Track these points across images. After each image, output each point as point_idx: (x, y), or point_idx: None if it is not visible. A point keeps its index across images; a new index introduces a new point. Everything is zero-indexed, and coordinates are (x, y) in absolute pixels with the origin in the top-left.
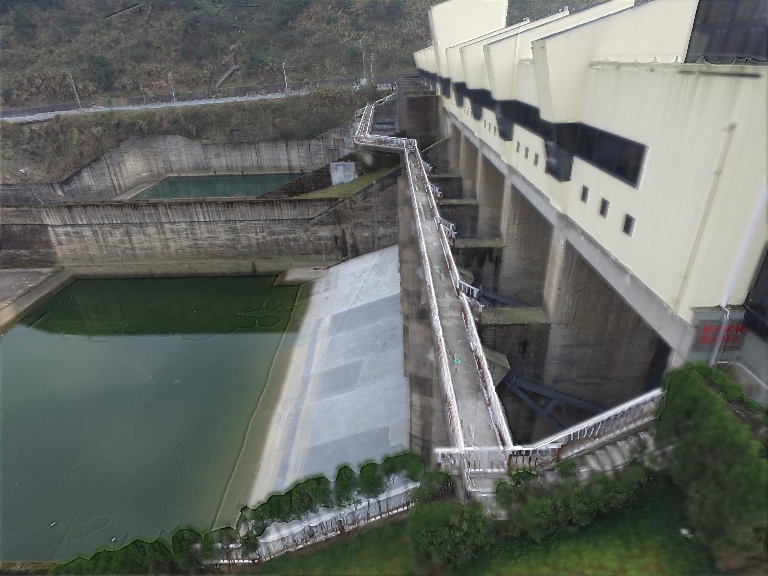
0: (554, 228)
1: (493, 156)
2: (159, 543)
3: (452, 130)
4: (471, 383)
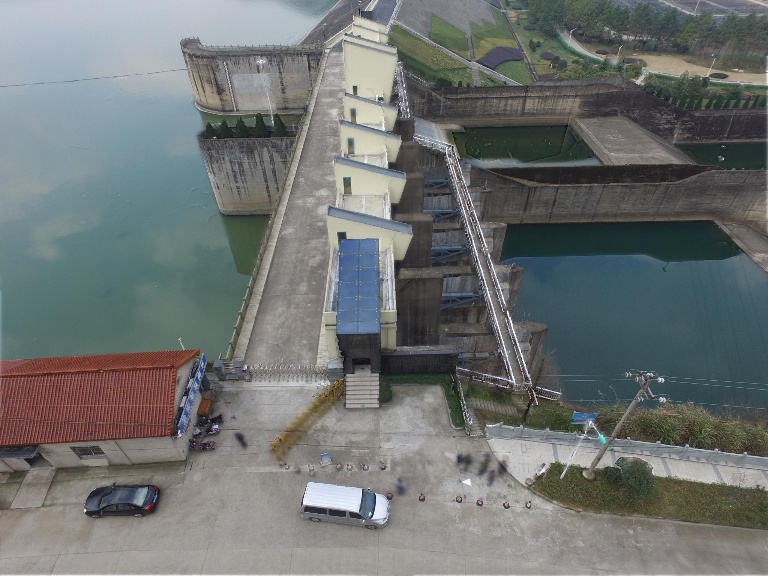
0: None
1: None
2: (437, 78)
3: None
4: (397, 71)
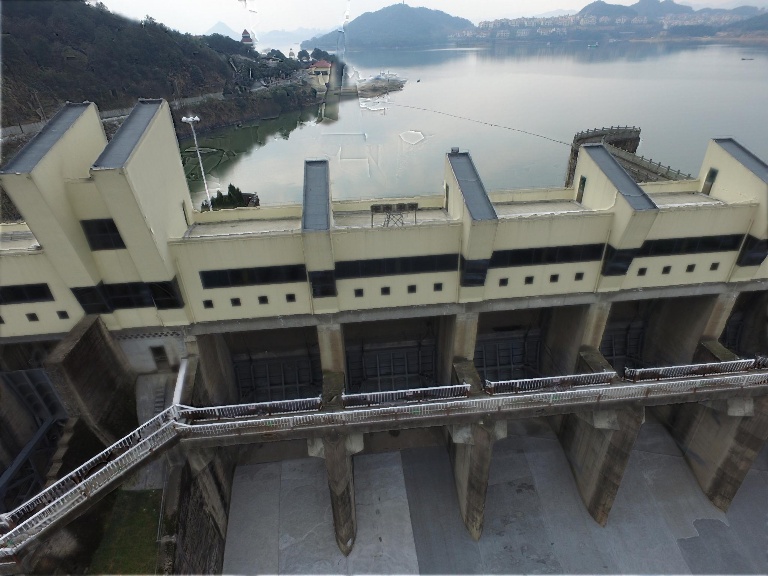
0: (721, 294)
1: (541, 301)
2: None
3: (198, 346)
4: None
